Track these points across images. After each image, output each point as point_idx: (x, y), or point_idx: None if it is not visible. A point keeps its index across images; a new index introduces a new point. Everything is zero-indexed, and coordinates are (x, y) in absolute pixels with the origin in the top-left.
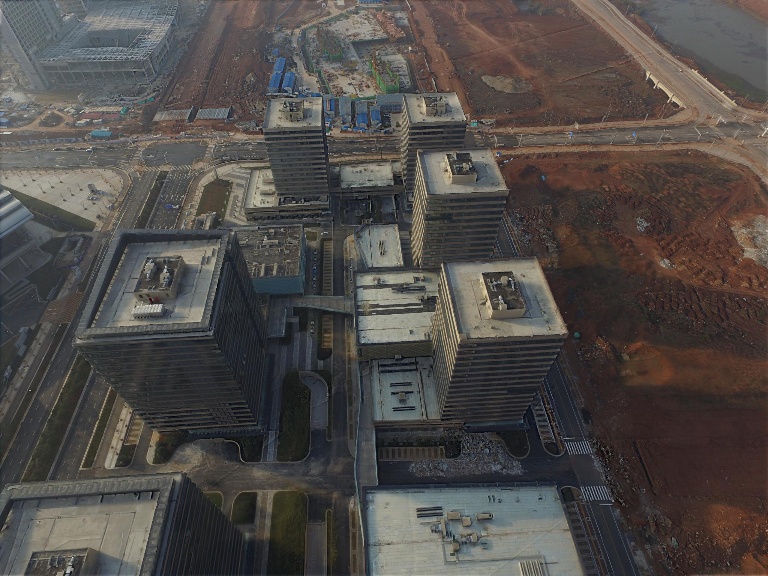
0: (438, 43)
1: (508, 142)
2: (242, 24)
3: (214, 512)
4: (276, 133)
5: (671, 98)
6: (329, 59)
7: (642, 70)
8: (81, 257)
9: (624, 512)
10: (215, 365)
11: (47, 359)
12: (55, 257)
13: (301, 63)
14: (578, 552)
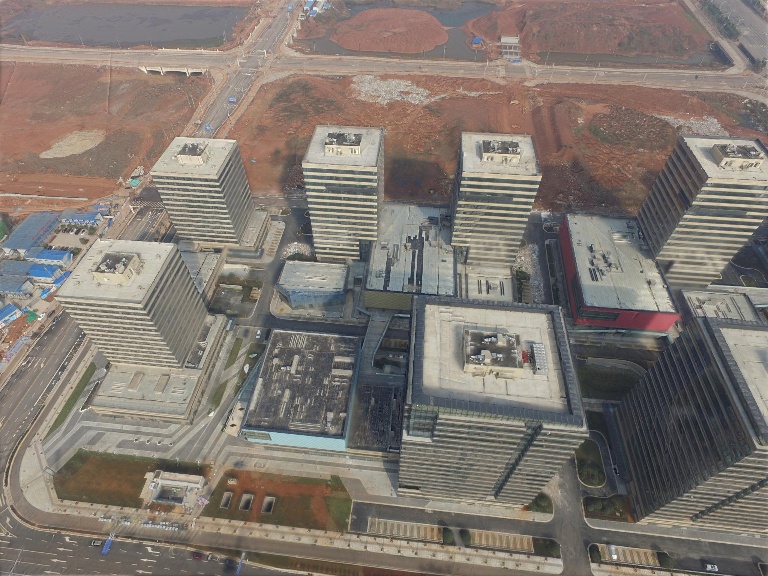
0: None
1: None
2: None
3: None
4: (151, 295)
5: (187, 72)
6: None
7: (134, 69)
8: None
9: (556, 211)
10: None
11: None
12: None
13: None
14: (605, 216)
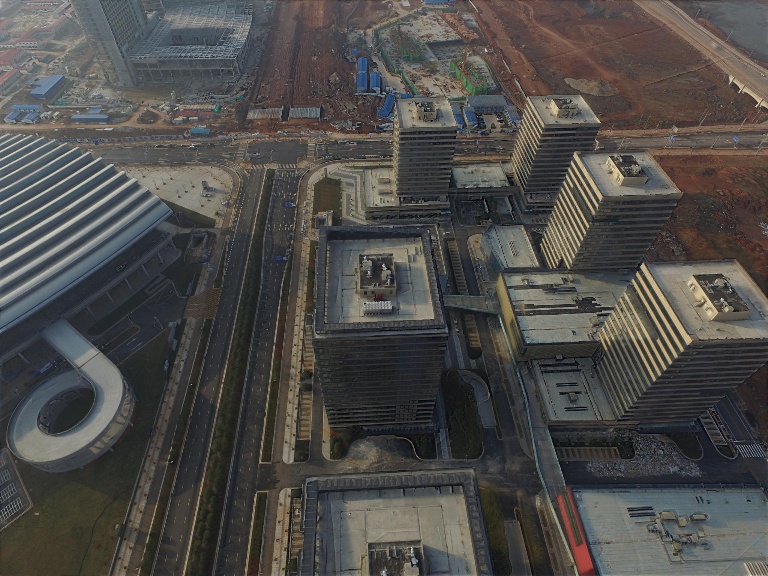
0: (513, 45)
1: (607, 145)
2: (313, 24)
3: None
4: (412, 133)
5: (760, 103)
6: (408, 60)
7: (724, 74)
8: (210, 253)
9: None
10: (432, 362)
11: (201, 354)
12: (184, 253)
13: (381, 63)
14: None
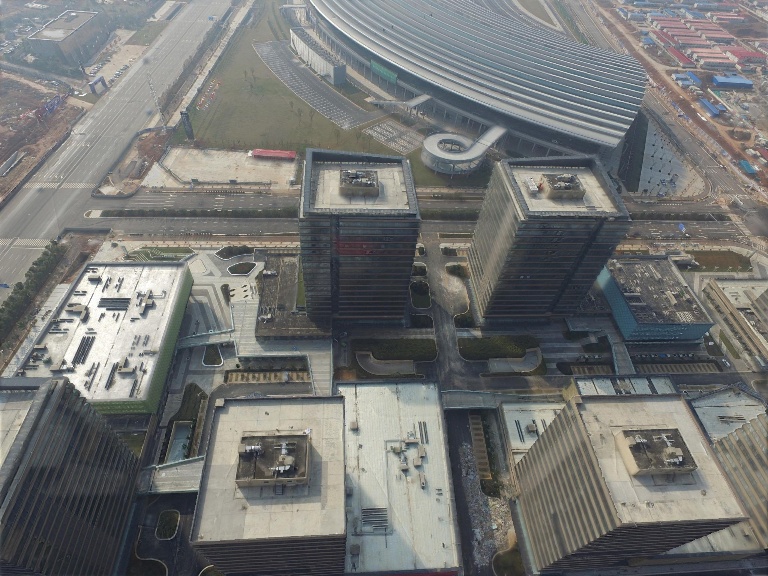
0: None
1: None
2: None
3: (408, 268)
4: None
5: None
6: None
7: None
8: None
9: None
10: (507, 244)
11: None
12: None
13: None
14: (396, 571)
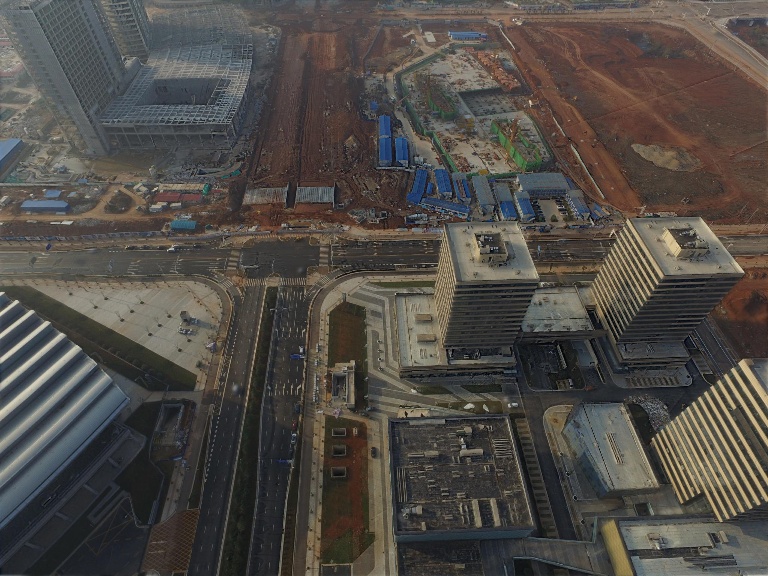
0: (562, 95)
1: None
2: (323, 65)
3: None
4: (473, 286)
5: None
6: (439, 117)
7: None
8: (186, 440)
9: None
10: None
11: None
12: (150, 440)
13: (406, 121)
14: None
